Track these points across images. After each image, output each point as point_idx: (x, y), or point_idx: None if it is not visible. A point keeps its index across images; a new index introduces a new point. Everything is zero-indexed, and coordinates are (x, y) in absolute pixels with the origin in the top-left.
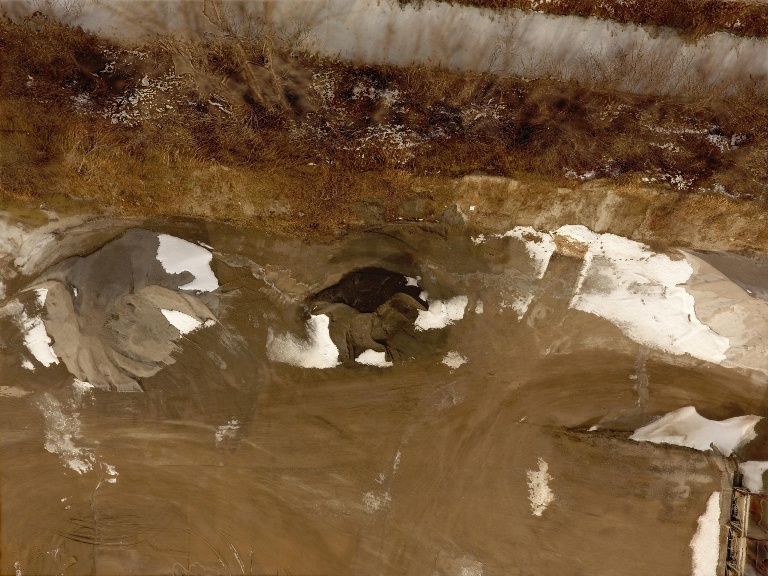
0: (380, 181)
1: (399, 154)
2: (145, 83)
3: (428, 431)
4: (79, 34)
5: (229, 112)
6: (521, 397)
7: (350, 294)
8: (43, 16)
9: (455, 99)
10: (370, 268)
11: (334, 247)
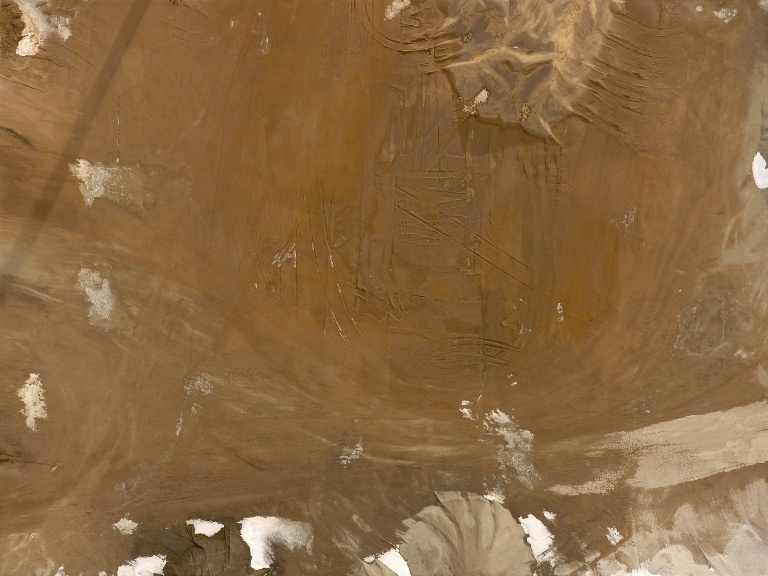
0: None
1: None
2: None
3: (149, 456)
4: None
5: None
6: (57, 491)
7: None
8: None
9: None
10: None
11: None
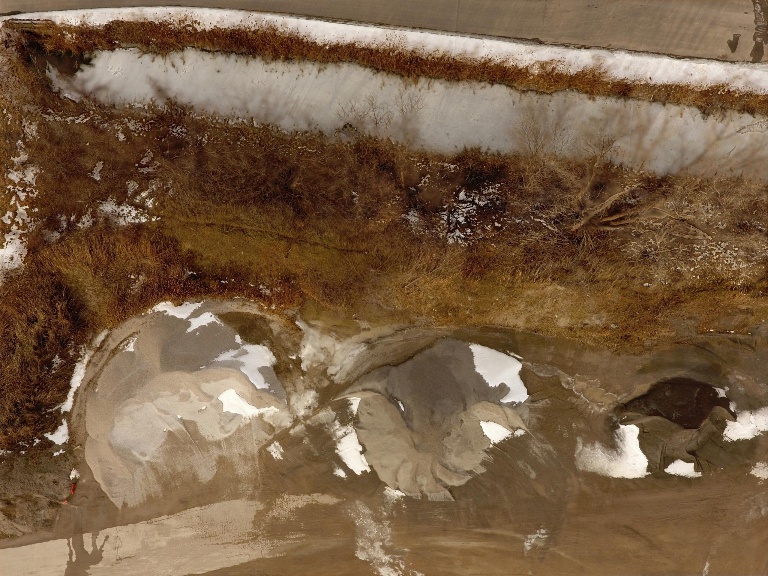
0: (709, 300)
1: (734, 275)
2: (462, 197)
3: (737, 542)
4: (391, 147)
5: (552, 228)
6: None
7: (665, 406)
8: (353, 128)
9: (767, 213)
10: (678, 379)
11: (643, 358)
